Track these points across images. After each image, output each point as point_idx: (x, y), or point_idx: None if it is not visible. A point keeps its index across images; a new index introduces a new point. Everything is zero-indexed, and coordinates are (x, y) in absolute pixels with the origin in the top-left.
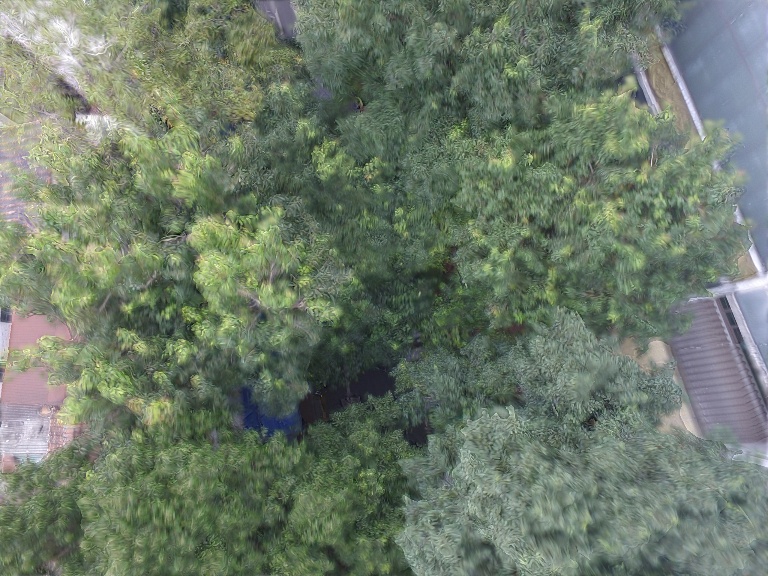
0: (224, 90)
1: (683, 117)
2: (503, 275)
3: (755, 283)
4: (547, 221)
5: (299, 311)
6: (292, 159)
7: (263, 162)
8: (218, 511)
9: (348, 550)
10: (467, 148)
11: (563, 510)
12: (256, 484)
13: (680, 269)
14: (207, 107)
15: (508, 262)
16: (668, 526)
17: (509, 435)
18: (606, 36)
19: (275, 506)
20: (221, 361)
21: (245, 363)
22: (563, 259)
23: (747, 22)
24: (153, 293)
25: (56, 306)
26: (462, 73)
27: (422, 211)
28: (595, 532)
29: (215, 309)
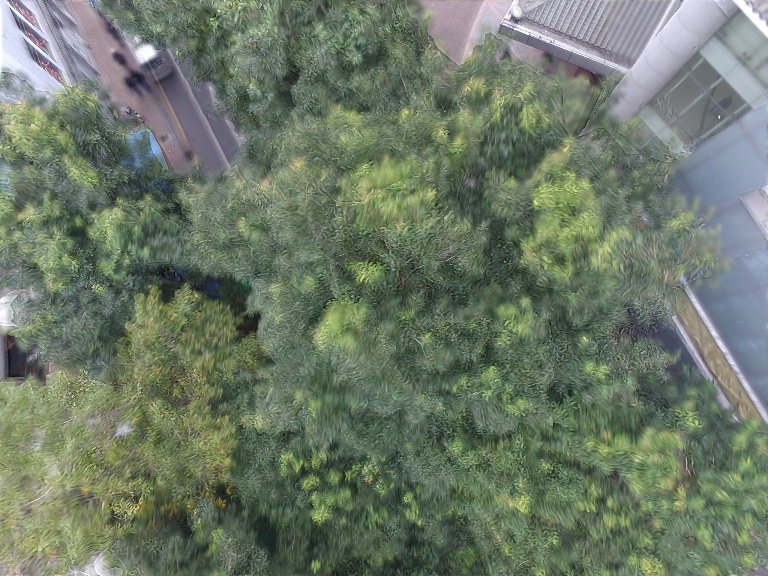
0: (191, 437)
1: (688, 309)
2: None
3: None
4: (579, 519)
5: None
6: (281, 484)
7: (250, 499)
8: None
9: None
10: (477, 462)
11: None
12: None
13: None
14: (176, 470)
15: (542, 563)
16: None
17: None
18: (616, 354)
19: None
20: None
21: None
22: None
23: (756, 265)
24: None
25: None
26: (461, 408)
27: (433, 488)
28: None
29: None
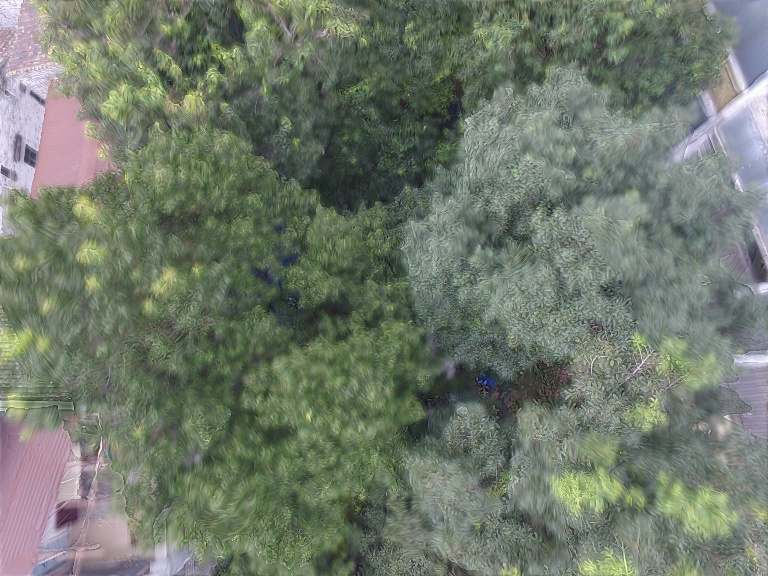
0: None
1: None
2: (505, 54)
3: (735, 104)
4: (546, 18)
5: (321, 42)
6: None
7: None
8: (246, 195)
9: (356, 291)
10: None
11: (553, 146)
12: (276, 208)
13: (666, 76)
14: None
15: (509, 60)
16: (643, 144)
17: (508, 109)
18: None
19: (293, 232)
20: (247, 104)
21: (268, 114)
22: (560, 40)
23: None
24: (189, 25)
25: (100, 35)
26: None
27: (430, 30)
28: (580, 169)
29: (248, 17)
